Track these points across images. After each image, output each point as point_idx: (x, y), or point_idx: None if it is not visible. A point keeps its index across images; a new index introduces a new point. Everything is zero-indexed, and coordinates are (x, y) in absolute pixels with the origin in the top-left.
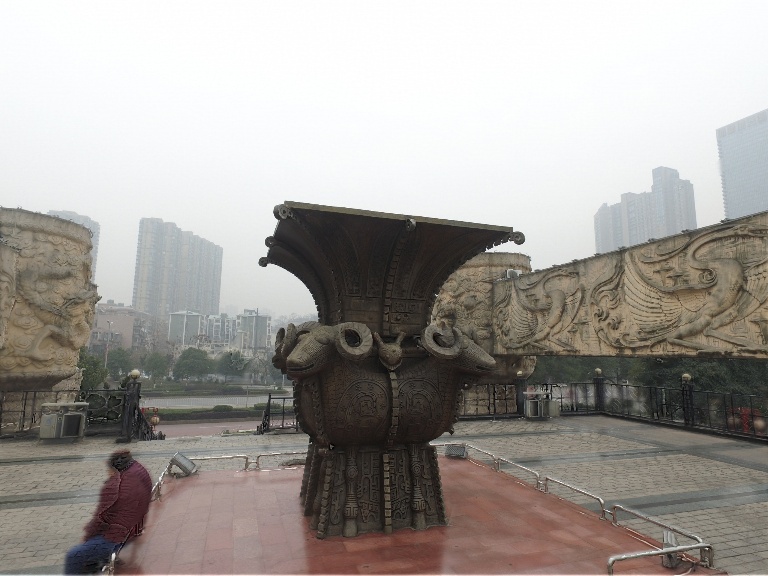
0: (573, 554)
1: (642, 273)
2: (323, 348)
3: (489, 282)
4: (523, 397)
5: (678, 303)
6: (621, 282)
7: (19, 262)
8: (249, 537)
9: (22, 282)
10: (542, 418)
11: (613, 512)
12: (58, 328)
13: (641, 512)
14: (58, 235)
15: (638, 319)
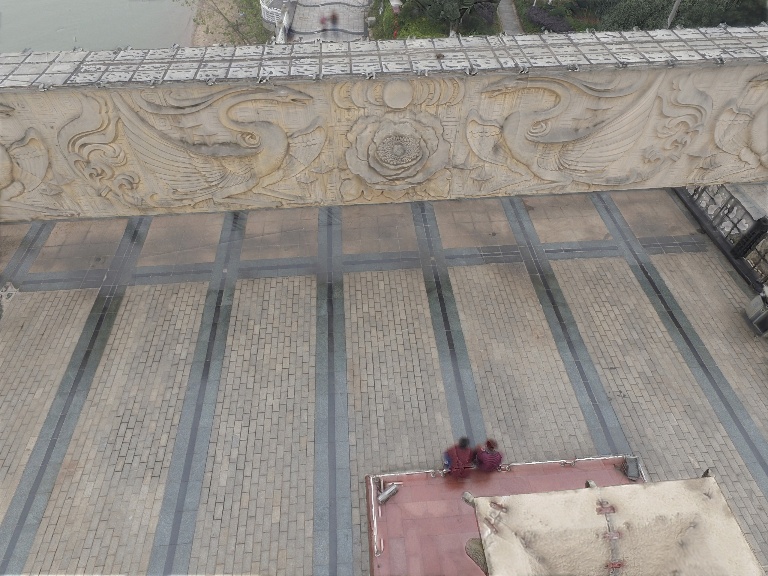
0: None
1: None
2: (482, 568)
3: None
4: None
5: None
6: None
7: None
8: None
9: None
10: None
11: None
12: None
13: None
14: None
15: None
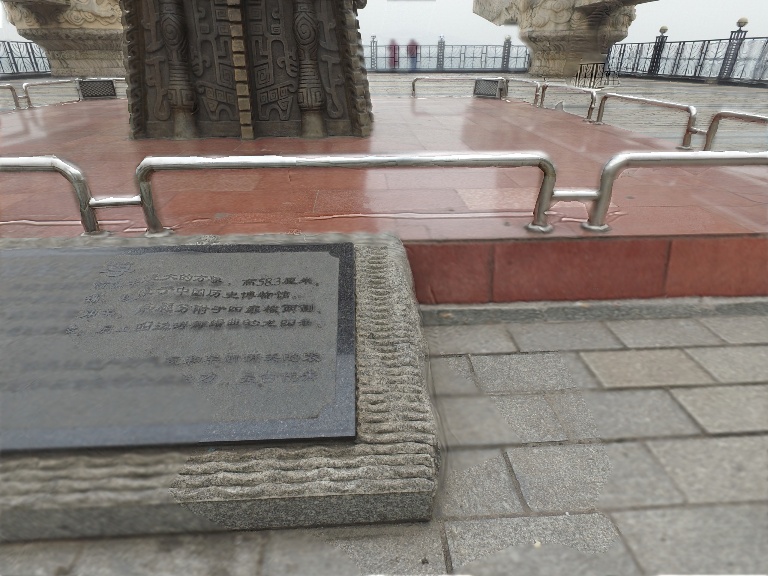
0: None
1: None
2: None
3: None
4: None
5: None
6: None
7: None
8: (443, 115)
9: None
10: None
11: None
12: None
13: None
14: None
15: None
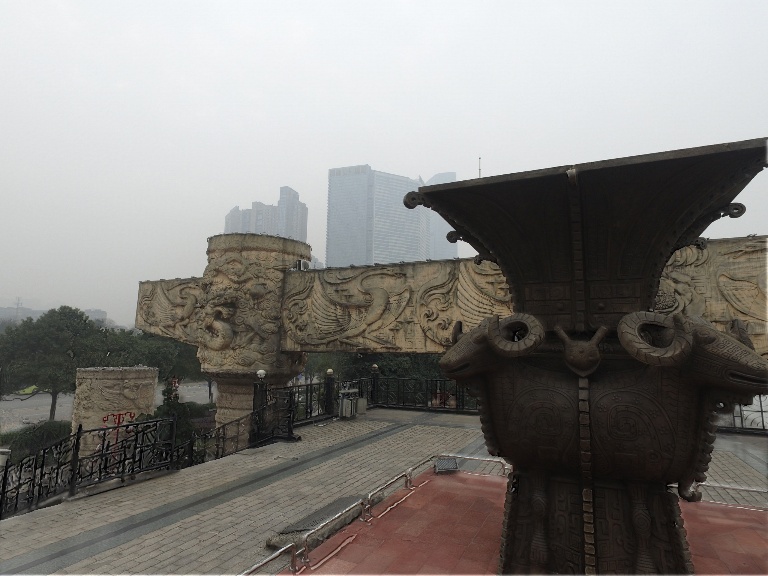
0: None
1: (475, 282)
2: None
3: (281, 270)
4: (332, 396)
5: (508, 310)
6: (454, 288)
7: None
8: None
9: None
10: (354, 416)
11: (697, 490)
12: None
13: None
14: None
15: (470, 321)
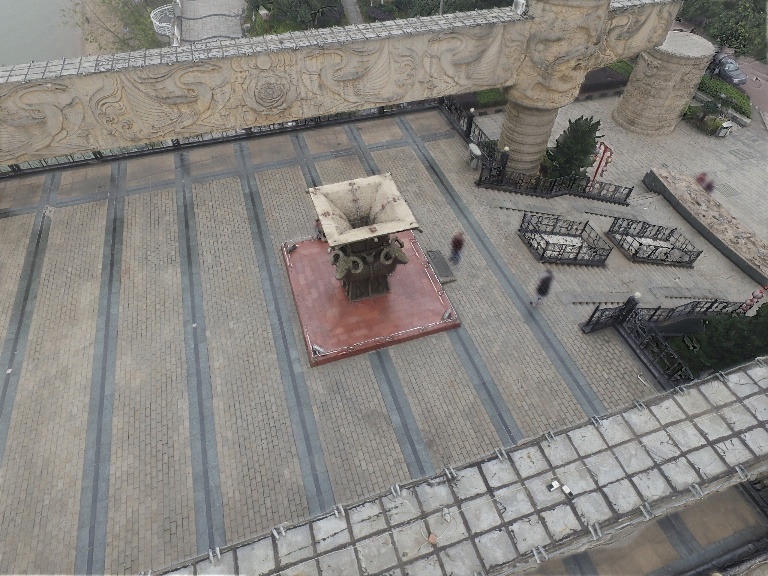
0: (325, 328)
1: None
2: None
3: None
4: None
5: None
6: None
7: (532, 27)
8: None
9: (530, 43)
10: None
11: None
12: (543, 79)
13: (381, 378)
14: (560, 5)
15: None
